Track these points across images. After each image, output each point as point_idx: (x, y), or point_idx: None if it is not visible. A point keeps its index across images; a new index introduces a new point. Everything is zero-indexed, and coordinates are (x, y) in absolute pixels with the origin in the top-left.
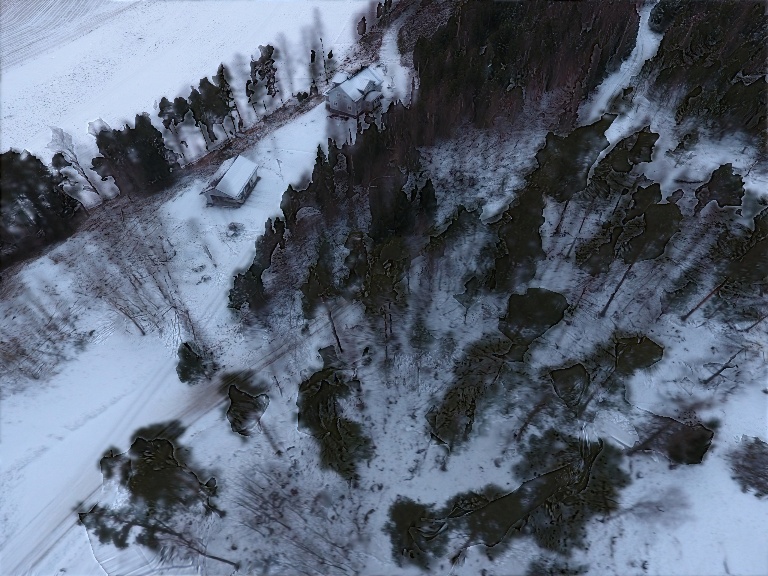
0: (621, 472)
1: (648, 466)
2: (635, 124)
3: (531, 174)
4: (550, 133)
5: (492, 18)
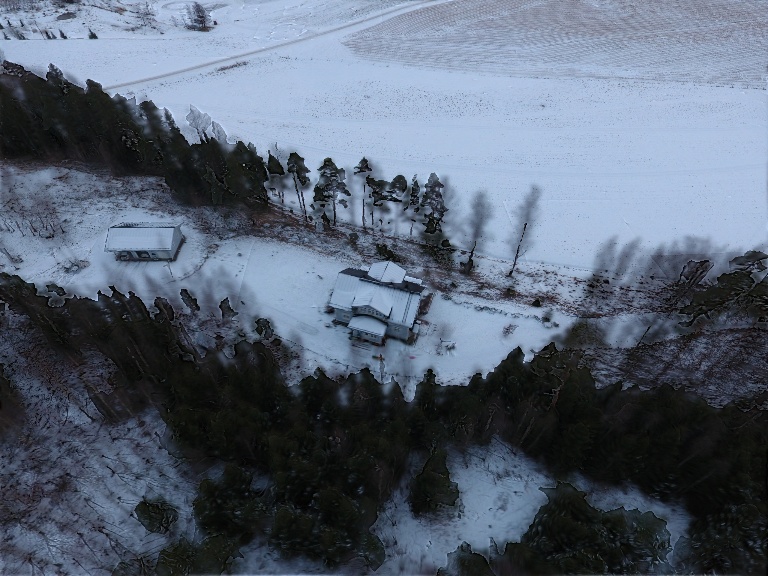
0: None
1: None
2: None
3: None
4: None
5: (713, 483)
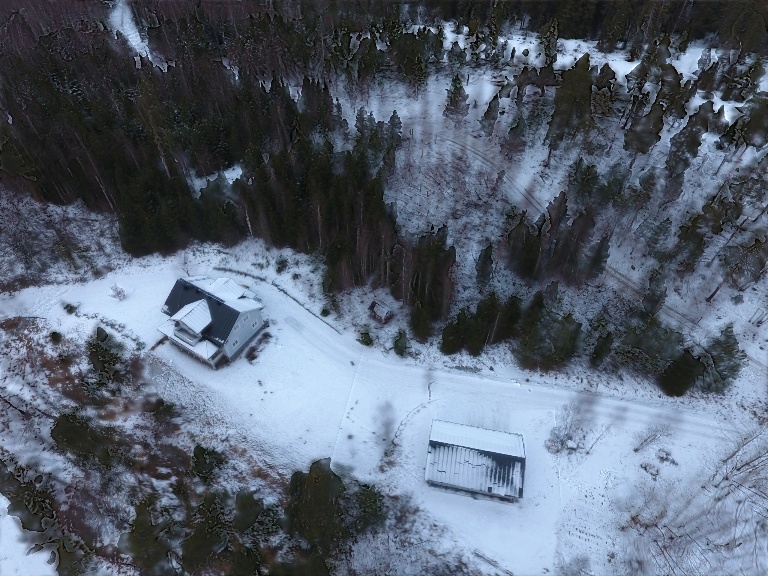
0: (741, 166)
1: (733, 156)
2: (388, 110)
3: (551, 136)
4: (567, 95)
5: None
